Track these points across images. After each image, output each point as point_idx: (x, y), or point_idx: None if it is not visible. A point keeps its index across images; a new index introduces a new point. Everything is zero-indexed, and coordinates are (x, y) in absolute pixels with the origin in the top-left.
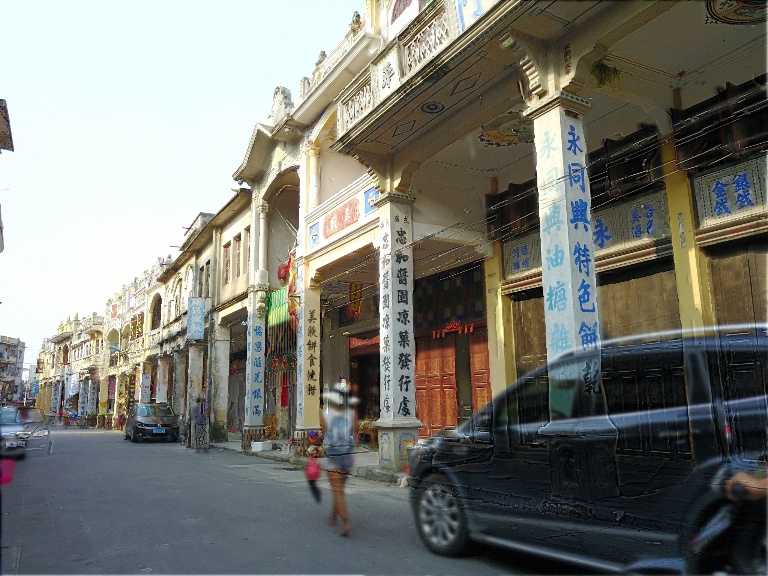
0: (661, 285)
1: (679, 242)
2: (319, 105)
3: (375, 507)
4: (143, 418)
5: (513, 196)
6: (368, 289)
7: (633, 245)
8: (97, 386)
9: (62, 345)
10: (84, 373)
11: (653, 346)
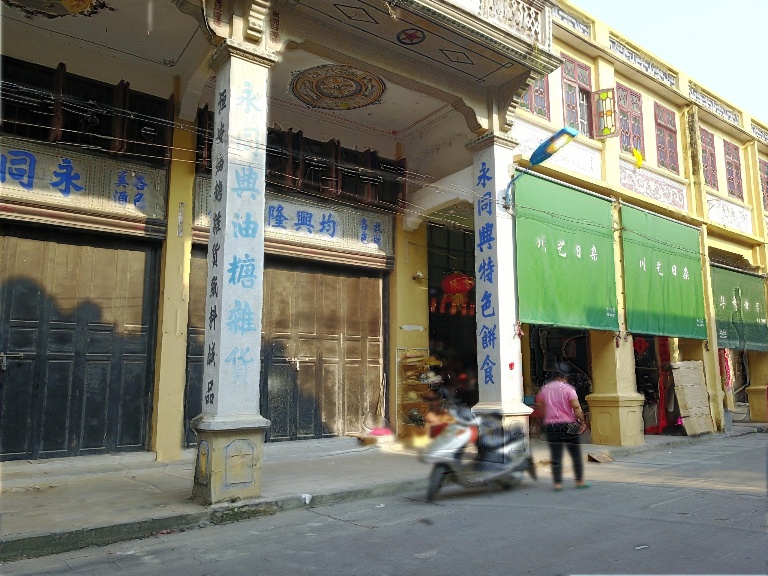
0: (126, 264)
1: (176, 230)
2: None
3: None
4: None
5: None
6: None
7: (115, 211)
8: None
9: None
10: None
11: (104, 328)
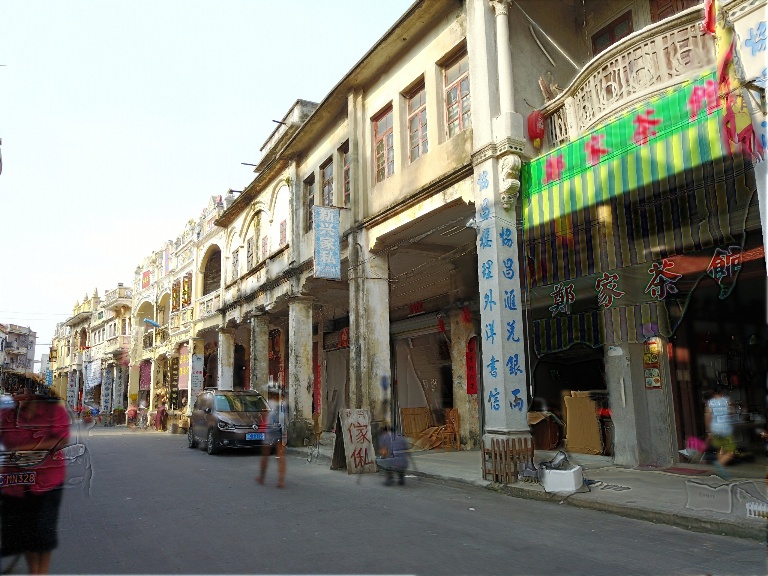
0: None
1: None
2: None
3: None
4: (227, 415)
5: None
6: None
7: None
8: (124, 374)
9: (79, 328)
10: (107, 359)
11: None
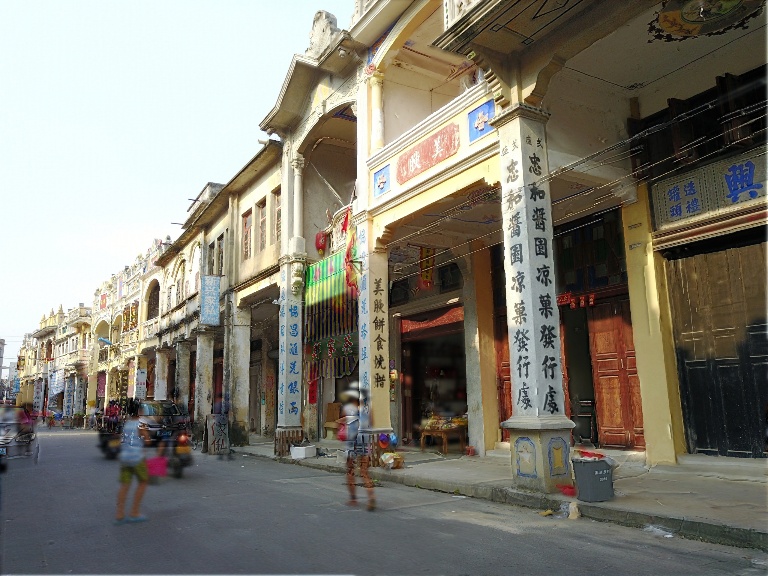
0: None
1: None
2: (390, 14)
3: (618, 569)
4: (145, 418)
5: (677, 115)
6: (441, 255)
7: None
8: (84, 383)
9: (45, 340)
10: (70, 369)
11: None
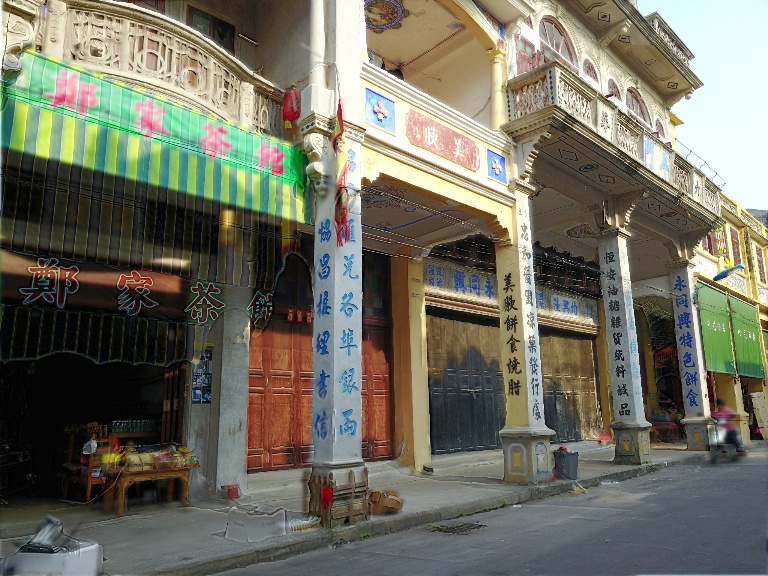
0: None
1: None
2: None
3: None
4: None
5: None
6: None
7: None
8: None
9: None
10: None
11: None
